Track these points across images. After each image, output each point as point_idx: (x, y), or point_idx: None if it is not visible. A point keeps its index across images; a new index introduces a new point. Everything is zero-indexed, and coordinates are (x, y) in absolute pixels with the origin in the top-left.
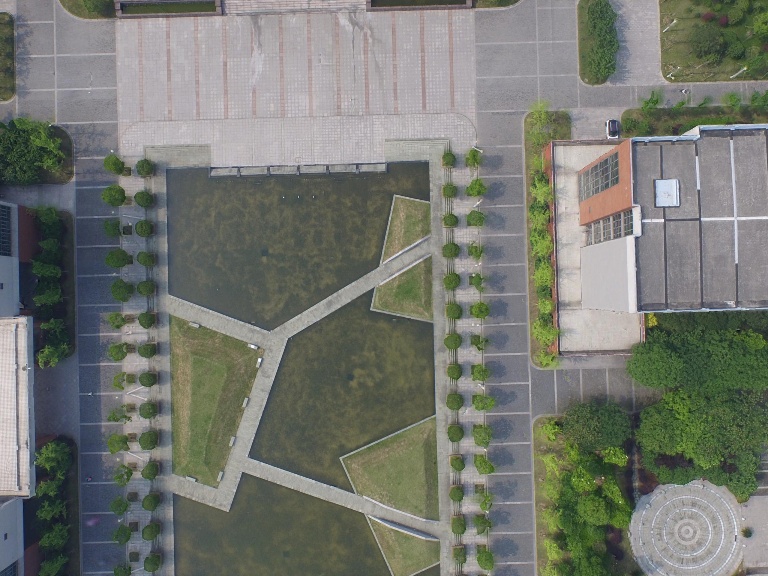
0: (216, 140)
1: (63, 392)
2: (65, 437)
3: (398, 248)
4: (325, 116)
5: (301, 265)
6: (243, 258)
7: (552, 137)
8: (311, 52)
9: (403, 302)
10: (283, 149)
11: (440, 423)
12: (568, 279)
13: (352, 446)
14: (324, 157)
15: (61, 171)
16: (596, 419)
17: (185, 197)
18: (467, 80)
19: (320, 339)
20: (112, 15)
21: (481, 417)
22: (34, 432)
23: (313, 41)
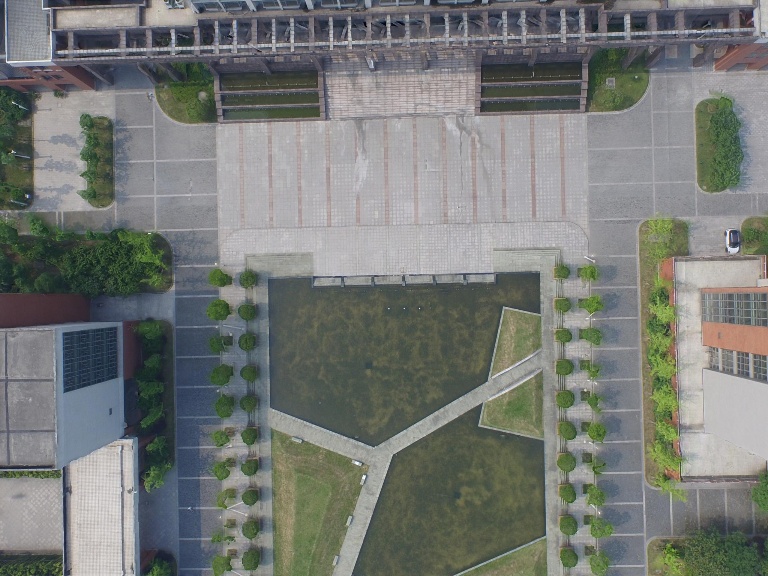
0: (319, 248)
1: (162, 506)
2: (164, 552)
3: (508, 363)
4: (431, 224)
5: (406, 378)
6: (346, 371)
7: (668, 247)
8: (417, 158)
9: (513, 419)
10: (388, 258)
11: (551, 544)
12: (690, 401)
13: (459, 566)
14: (430, 267)
15: (161, 280)
16: (722, 552)
17: (287, 307)
18: (579, 187)
19: (426, 455)
20: (213, 120)
21: (593, 538)
22: (139, 556)
23: (419, 146)
